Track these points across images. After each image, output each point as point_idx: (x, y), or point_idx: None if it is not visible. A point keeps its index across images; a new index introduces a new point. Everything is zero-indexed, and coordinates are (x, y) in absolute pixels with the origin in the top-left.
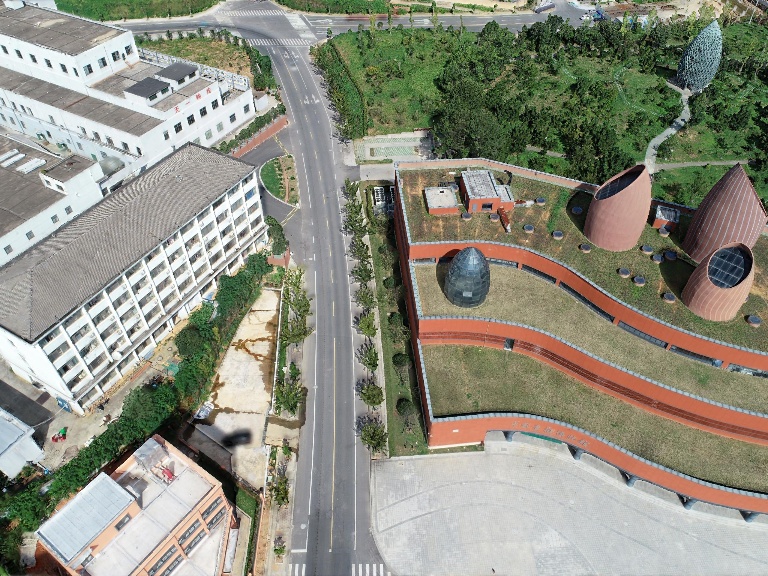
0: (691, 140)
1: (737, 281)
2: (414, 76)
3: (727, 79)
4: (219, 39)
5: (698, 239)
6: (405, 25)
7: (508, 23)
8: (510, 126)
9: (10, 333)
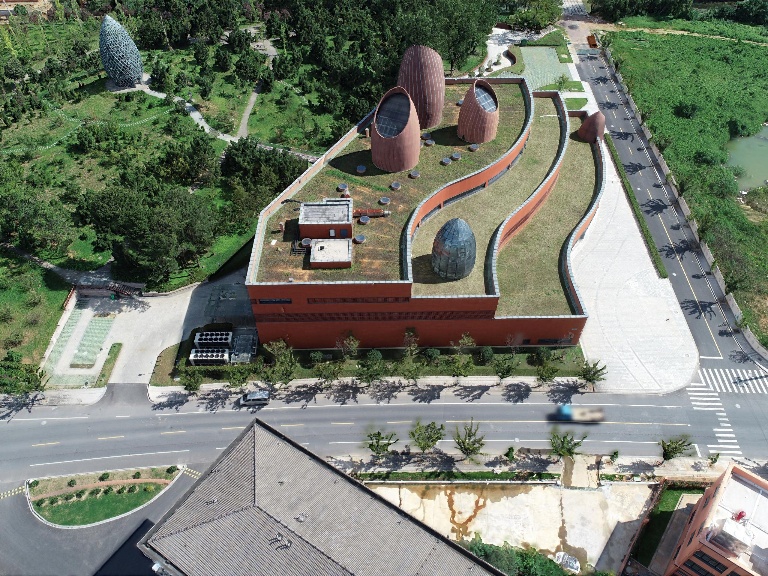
0: (215, 108)
1: (493, 101)
2: None
3: None
4: None
5: (428, 112)
6: None
7: None
8: None
9: None
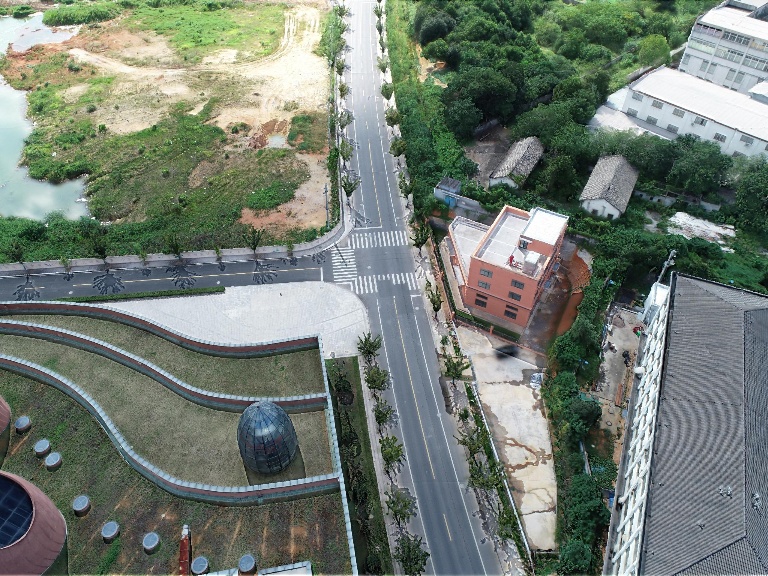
0: None
1: None
2: None
3: None
4: None
5: None
6: None
7: None
8: None
9: (703, 279)
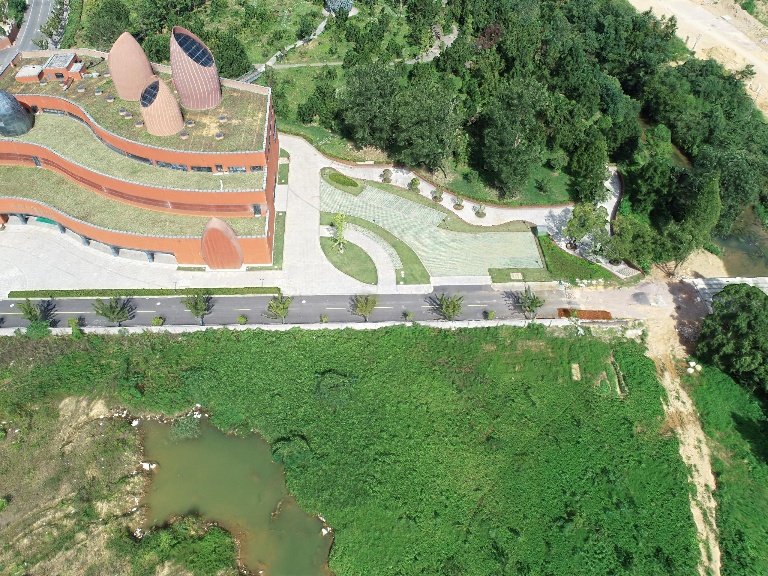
0: (309, 48)
1: None
2: None
3: (371, 6)
4: None
5: None
6: None
7: None
8: None
9: None
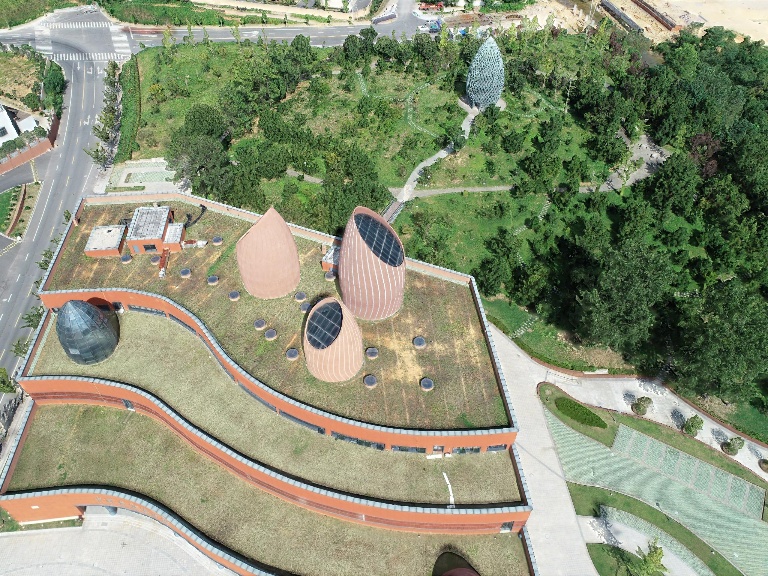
0: (459, 164)
1: (332, 341)
2: (202, 94)
3: (522, 97)
4: (21, 54)
5: (340, 287)
6: (230, 37)
7: (339, 35)
8: (280, 149)
9: None
